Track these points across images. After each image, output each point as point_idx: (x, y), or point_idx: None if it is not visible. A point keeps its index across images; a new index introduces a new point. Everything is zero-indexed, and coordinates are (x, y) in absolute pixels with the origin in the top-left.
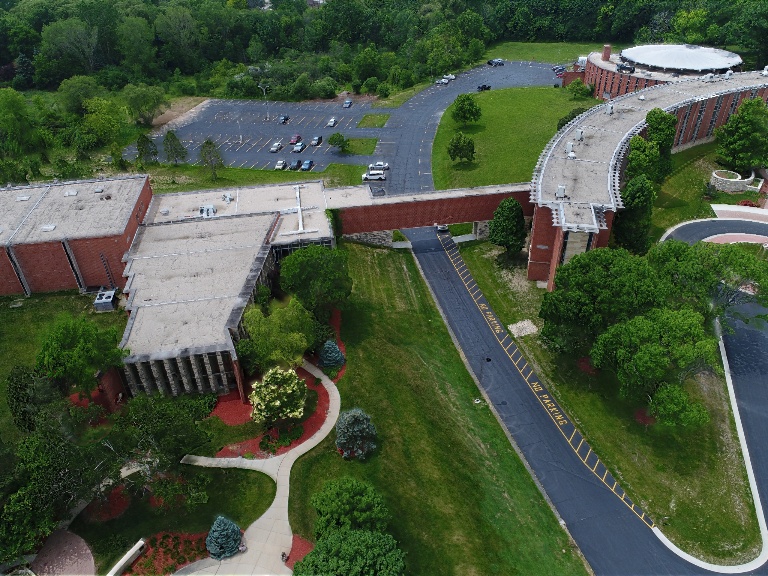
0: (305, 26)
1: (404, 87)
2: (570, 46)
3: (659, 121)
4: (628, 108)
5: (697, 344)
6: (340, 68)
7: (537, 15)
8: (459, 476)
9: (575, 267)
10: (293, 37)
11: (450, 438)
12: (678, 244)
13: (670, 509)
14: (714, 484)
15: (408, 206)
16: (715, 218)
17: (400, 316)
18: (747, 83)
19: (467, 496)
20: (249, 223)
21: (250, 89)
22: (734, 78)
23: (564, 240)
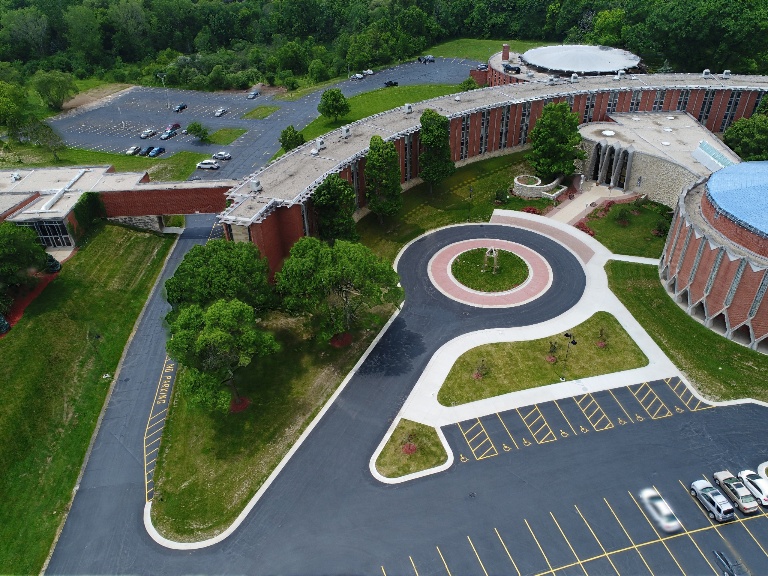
0: (260, 18)
1: (318, 81)
2: (517, 44)
3: (429, 122)
4: (433, 108)
5: (215, 334)
6: (268, 60)
7: (494, 12)
8: (17, 438)
9: (191, 256)
10: (248, 29)
11: (42, 405)
12: (305, 241)
13: (179, 487)
14: (238, 470)
15: (165, 193)
16: (486, 223)
17: (103, 295)
18: (587, 87)
19: (7, 456)
20: (4, 201)
21: (171, 78)
22: (580, 82)
23: (230, 232)
